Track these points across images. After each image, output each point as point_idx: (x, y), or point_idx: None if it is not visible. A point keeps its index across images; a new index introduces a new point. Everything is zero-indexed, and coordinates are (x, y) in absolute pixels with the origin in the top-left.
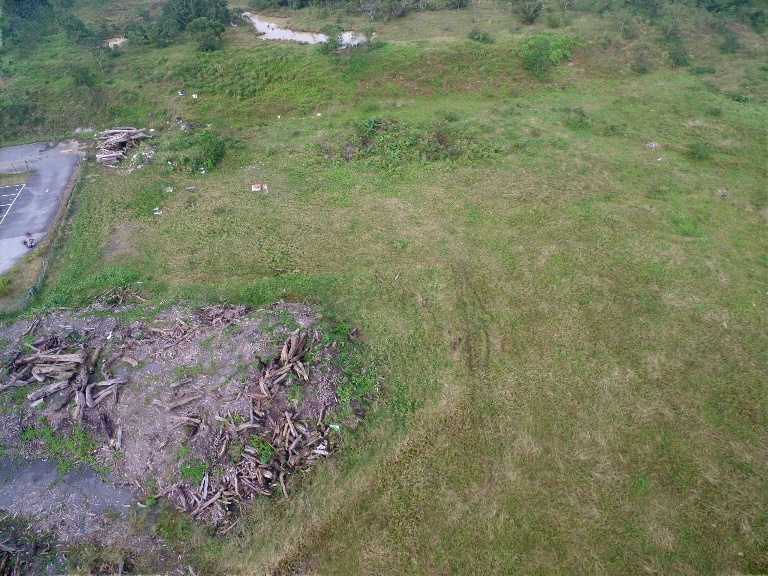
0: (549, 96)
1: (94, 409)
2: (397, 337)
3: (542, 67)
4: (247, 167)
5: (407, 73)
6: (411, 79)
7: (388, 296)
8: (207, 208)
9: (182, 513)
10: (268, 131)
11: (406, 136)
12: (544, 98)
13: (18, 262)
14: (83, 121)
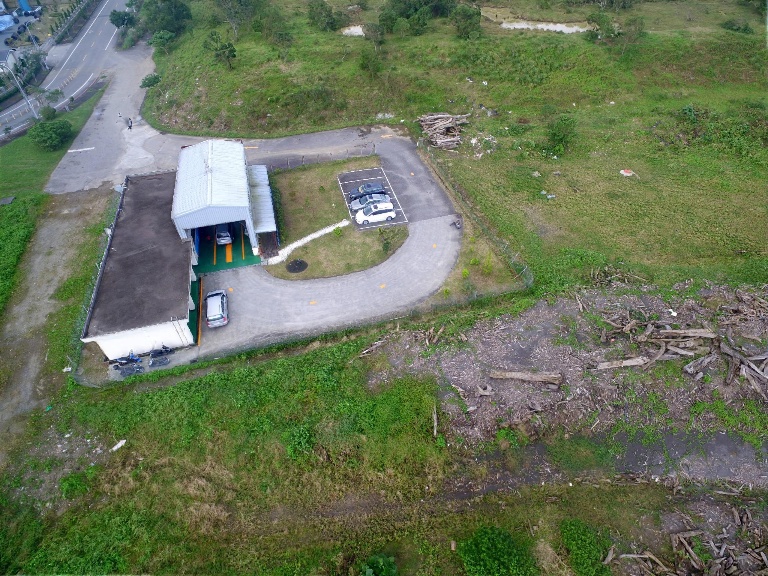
0: None
1: (767, 383)
2: None
3: None
4: (593, 153)
5: (680, 63)
6: (685, 69)
7: None
8: (597, 192)
9: None
10: (578, 118)
11: (732, 124)
12: None
13: (463, 242)
14: (382, 107)
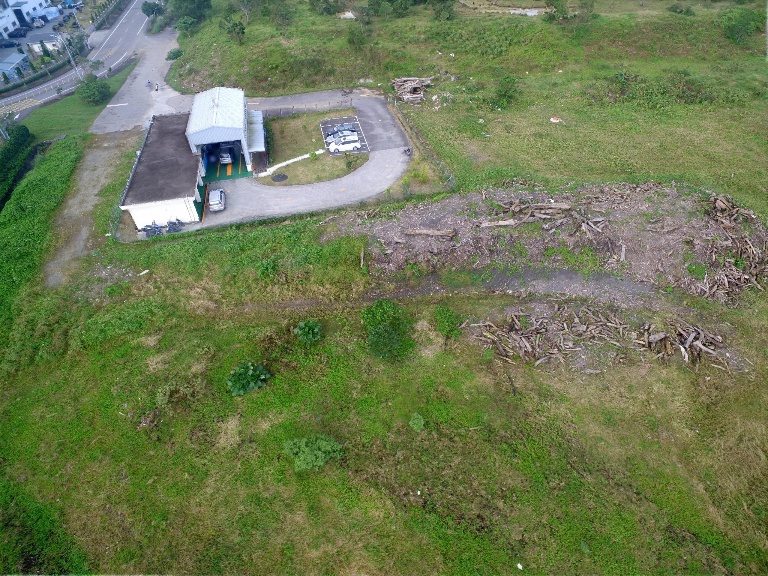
0: (755, 60)
1: (599, 234)
2: (767, 210)
3: (742, 36)
4: (533, 107)
5: (625, 39)
6: (629, 44)
7: (736, 186)
8: (526, 133)
9: (697, 296)
10: (527, 82)
11: None
12: (752, 61)
13: (409, 164)
14: (364, 73)
